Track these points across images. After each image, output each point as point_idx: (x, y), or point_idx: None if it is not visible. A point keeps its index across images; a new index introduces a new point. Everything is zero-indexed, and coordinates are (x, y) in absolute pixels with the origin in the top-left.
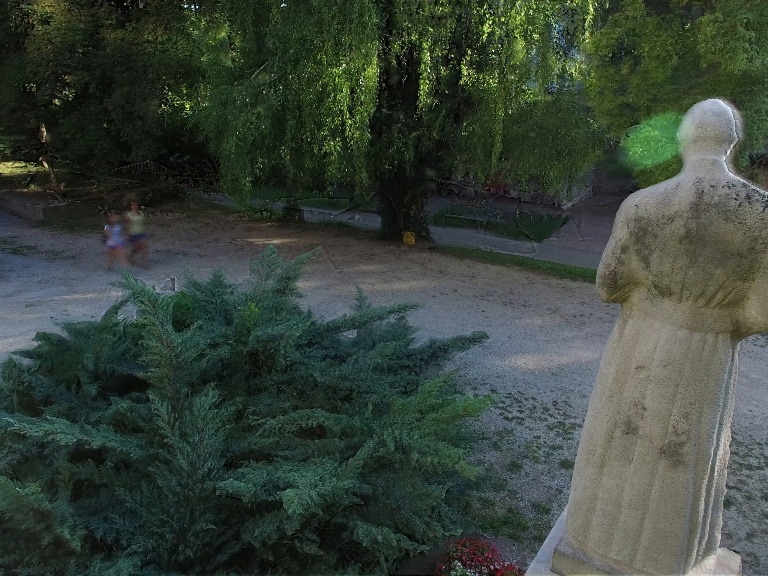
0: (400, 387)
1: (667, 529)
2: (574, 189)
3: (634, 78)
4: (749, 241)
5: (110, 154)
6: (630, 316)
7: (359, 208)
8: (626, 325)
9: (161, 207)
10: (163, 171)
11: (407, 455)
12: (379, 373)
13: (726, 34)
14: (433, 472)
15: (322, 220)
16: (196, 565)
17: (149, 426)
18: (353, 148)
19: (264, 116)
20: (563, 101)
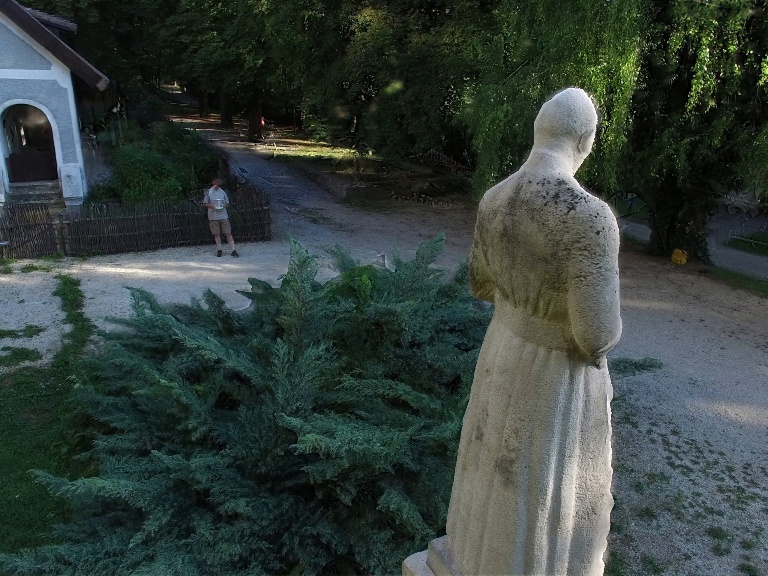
0: None
1: (499, 550)
2: None
3: None
4: (551, 245)
5: (399, 145)
6: (494, 317)
7: (627, 217)
8: None
9: (436, 196)
10: (452, 164)
11: None
12: None
13: None
14: None
15: None
16: (269, 482)
17: None
18: (605, 151)
19: (519, 114)
20: None
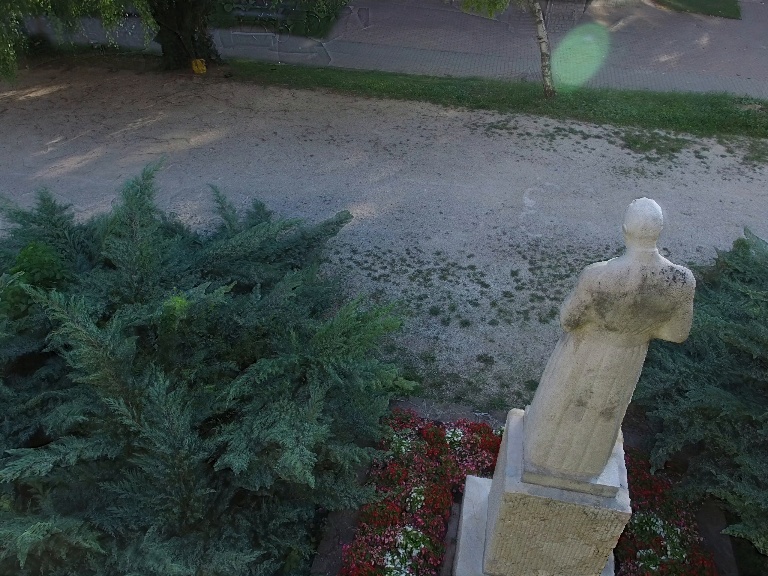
0: None
1: (600, 451)
2: None
3: None
4: (672, 305)
5: None
6: (583, 338)
7: None
8: (580, 344)
9: None
10: None
11: (348, 378)
12: (273, 284)
13: None
14: None
15: None
16: (204, 520)
17: (107, 422)
18: None
19: None
20: None
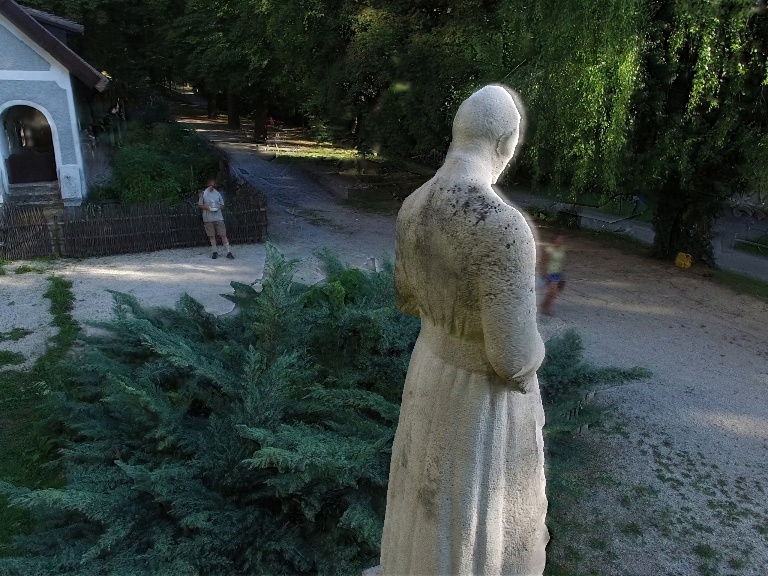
0: None
1: None
2: None
3: None
4: (459, 259)
5: (399, 146)
6: None
7: (630, 220)
8: None
9: None
10: None
11: None
12: None
13: None
14: None
15: (603, 229)
16: (235, 494)
17: None
18: (604, 152)
19: None
20: None
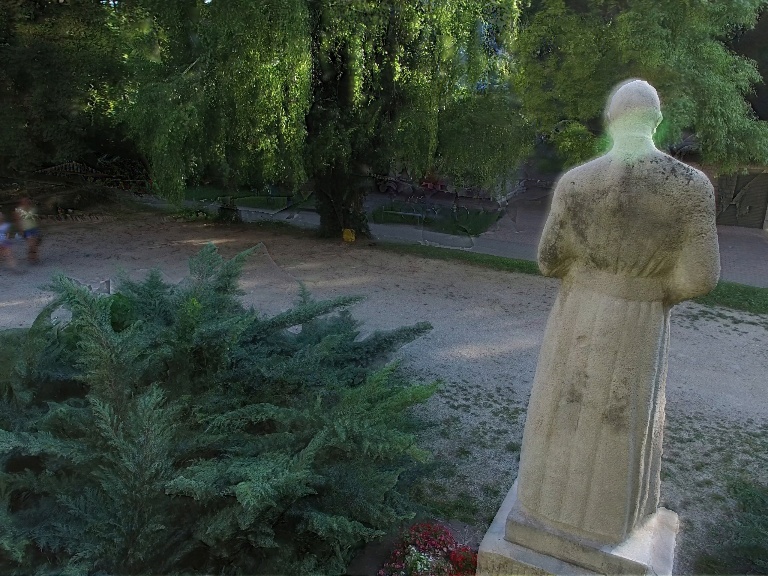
0: (348, 379)
1: (610, 490)
2: (508, 183)
3: (561, 74)
4: (676, 212)
5: (33, 155)
6: (570, 289)
7: (298, 206)
8: (566, 298)
9: (90, 210)
10: (91, 173)
11: (358, 444)
12: (326, 367)
13: (645, 31)
14: (383, 461)
15: (260, 220)
16: (146, 568)
17: (90, 430)
18: (290, 145)
19: None
20: (495, 97)
